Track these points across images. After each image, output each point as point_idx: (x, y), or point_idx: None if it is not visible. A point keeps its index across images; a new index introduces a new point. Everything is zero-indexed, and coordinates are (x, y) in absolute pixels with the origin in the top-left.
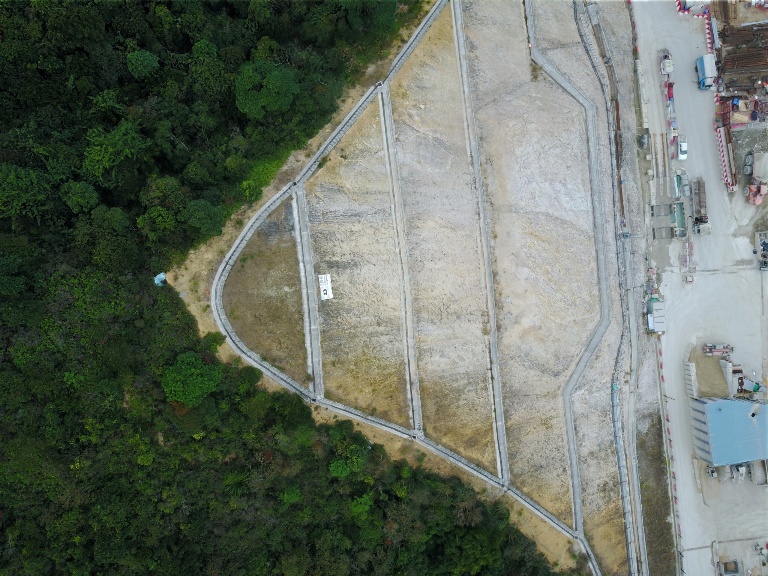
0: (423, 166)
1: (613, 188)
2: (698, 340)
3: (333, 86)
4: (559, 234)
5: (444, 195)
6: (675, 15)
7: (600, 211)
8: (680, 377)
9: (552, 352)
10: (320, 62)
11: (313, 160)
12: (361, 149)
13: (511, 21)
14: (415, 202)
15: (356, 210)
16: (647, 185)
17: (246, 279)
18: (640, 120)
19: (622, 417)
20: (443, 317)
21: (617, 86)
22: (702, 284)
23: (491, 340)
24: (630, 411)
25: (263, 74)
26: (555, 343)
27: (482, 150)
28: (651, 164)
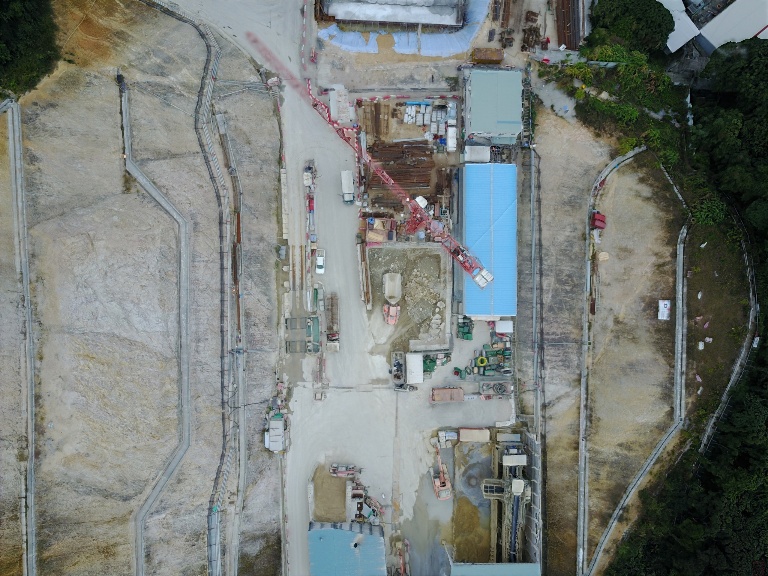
0: None
1: (222, 303)
2: (327, 459)
3: None
4: (124, 356)
5: None
6: (325, 126)
7: (186, 331)
8: (305, 496)
9: (114, 477)
10: None
11: None
12: None
13: (100, 131)
14: None
15: None
16: (283, 297)
17: None
18: (282, 230)
19: (223, 540)
20: None
21: (241, 198)
22: (335, 401)
23: (28, 467)
24: (234, 533)
25: None
26: (115, 469)
27: (33, 267)
28: (289, 276)
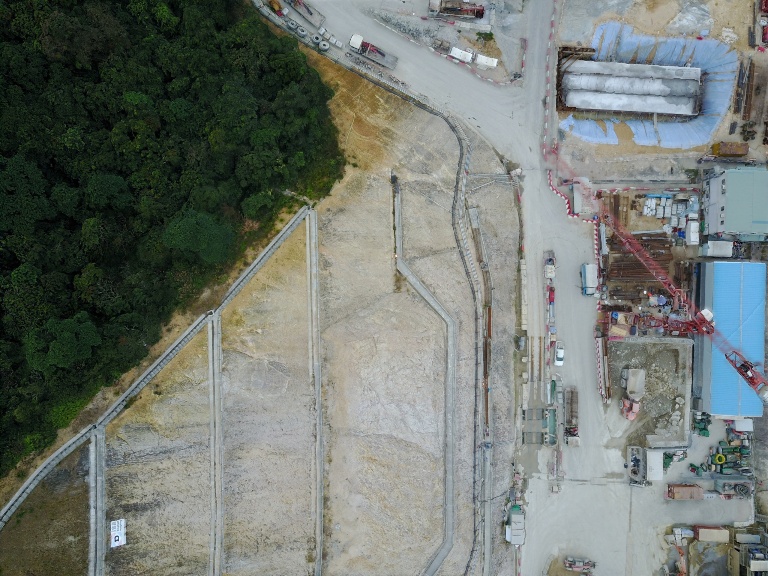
0: (253, 393)
1: (476, 399)
2: (560, 551)
3: (158, 316)
4: (401, 458)
5: (275, 420)
6: (564, 217)
7: (452, 430)
8: None
9: None
10: (142, 296)
11: (122, 398)
12: (181, 382)
13: (377, 232)
14: (239, 432)
15: (167, 446)
16: (521, 387)
17: (22, 534)
18: (520, 320)
19: None
20: (260, 549)
21: (492, 292)
22: (569, 494)
23: (316, 567)
24: None
25: (53, 335)
26: (389, 568)
27: (325, 371)
28: (527, 366)
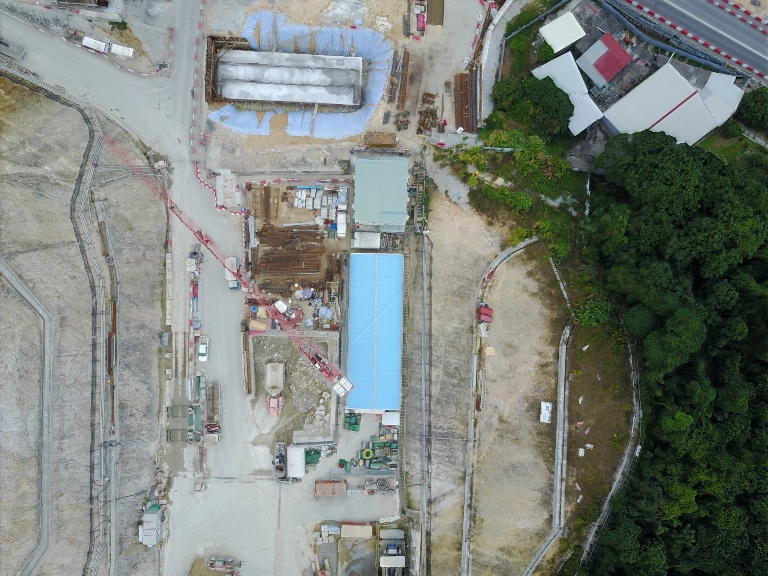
0: None
1: (93, 396)
2: (206, 551)
3: None
4: None
5: None
6: (213, 210)
7: (48, 429)
8: None
9: None
10: None
11: None
12: None
13: None
14: None
15: None
16: None
17: None
18: None
19: None
20: None
21: (117, 287)
22: (216, 492)
23: None
24: None
25: None
26: None
27: None
28: (172, 363)
